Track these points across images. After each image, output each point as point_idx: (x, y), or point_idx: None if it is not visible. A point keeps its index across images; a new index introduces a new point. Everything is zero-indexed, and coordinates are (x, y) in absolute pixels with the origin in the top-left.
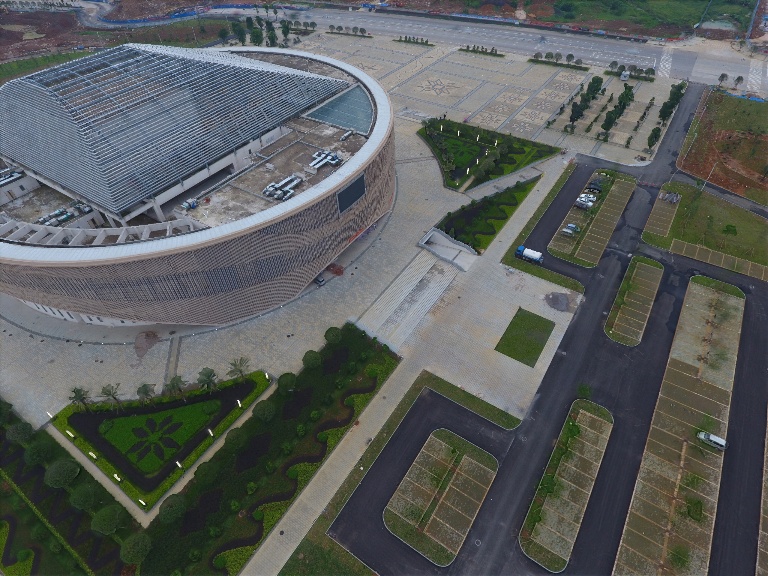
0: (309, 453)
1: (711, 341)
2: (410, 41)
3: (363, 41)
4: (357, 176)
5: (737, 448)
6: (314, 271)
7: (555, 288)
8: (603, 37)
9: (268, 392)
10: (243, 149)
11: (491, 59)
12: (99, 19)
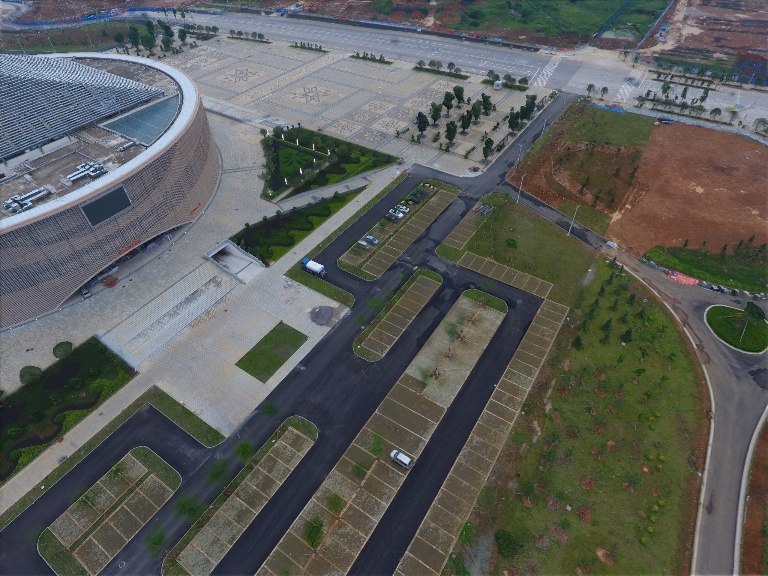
0: None
1: (450, 357)
2: (305, 47)
3: (260, 46)
4: (111, 188)
5: (425, 467)
6: (73, 284)
7: (325, 301)
8: (498, 45)
9: None
10: (17, 159)
11: (377, 66)
12: (9, 21)
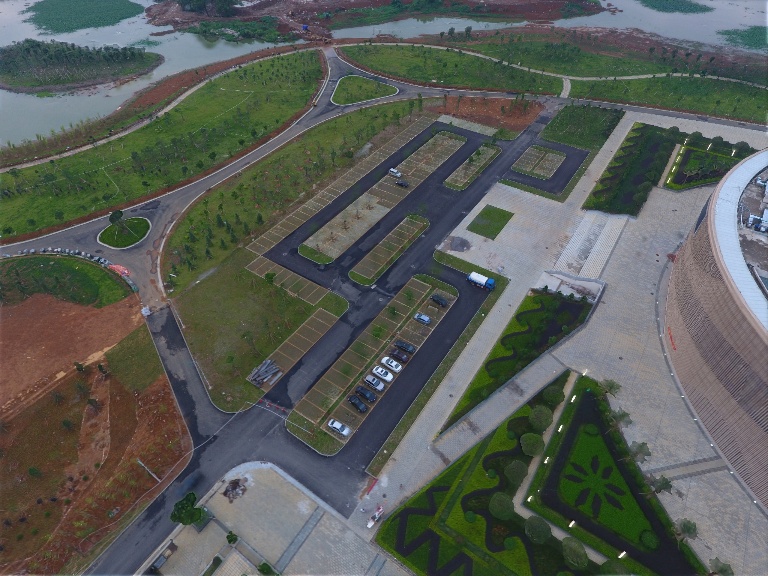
0: (616, 169)
1: None
2: None
3: None
4: None
5: (382, 173)
6: None
7: (460, 255)
8: None
9: (662, 183)
10: None
11: None
12: None
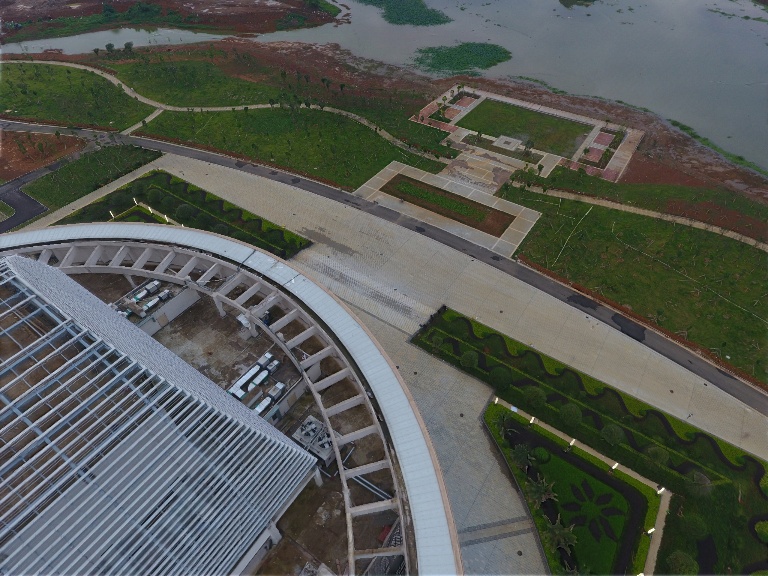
0: None
1: None
2: None
3: None
4: None
5: None
6: None
7: None
8: None
9: None
10: None
11: None
12: None
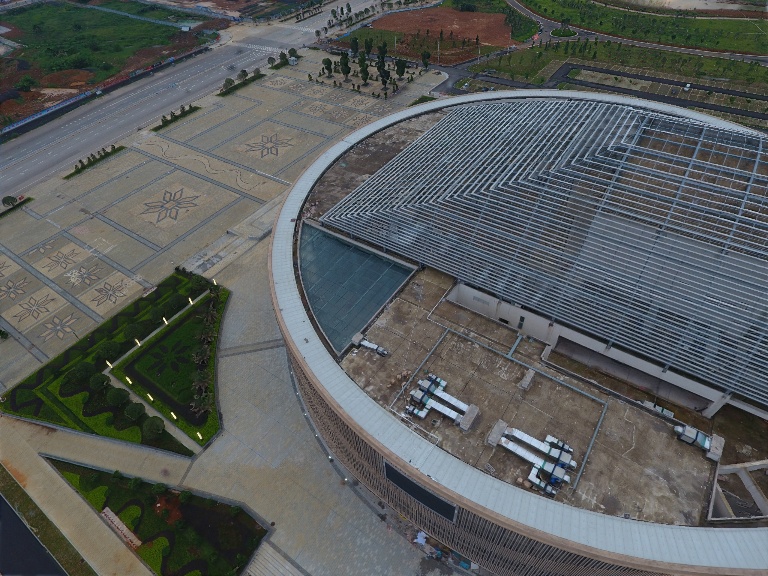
0: None
1: None
2: (91, 162)
3: (39, 207)
4: None
5: None
6: None
7: None
8: (184, 61)
9: None
10: None
11: (202, 114)
12: None
